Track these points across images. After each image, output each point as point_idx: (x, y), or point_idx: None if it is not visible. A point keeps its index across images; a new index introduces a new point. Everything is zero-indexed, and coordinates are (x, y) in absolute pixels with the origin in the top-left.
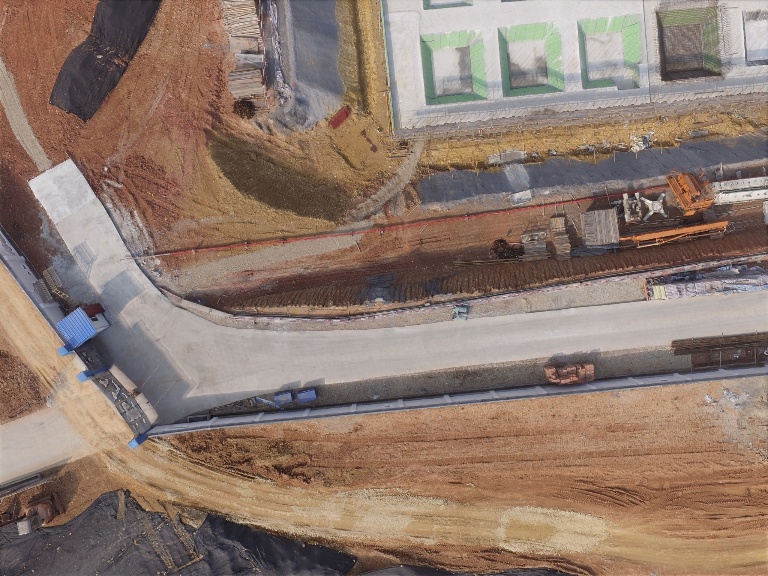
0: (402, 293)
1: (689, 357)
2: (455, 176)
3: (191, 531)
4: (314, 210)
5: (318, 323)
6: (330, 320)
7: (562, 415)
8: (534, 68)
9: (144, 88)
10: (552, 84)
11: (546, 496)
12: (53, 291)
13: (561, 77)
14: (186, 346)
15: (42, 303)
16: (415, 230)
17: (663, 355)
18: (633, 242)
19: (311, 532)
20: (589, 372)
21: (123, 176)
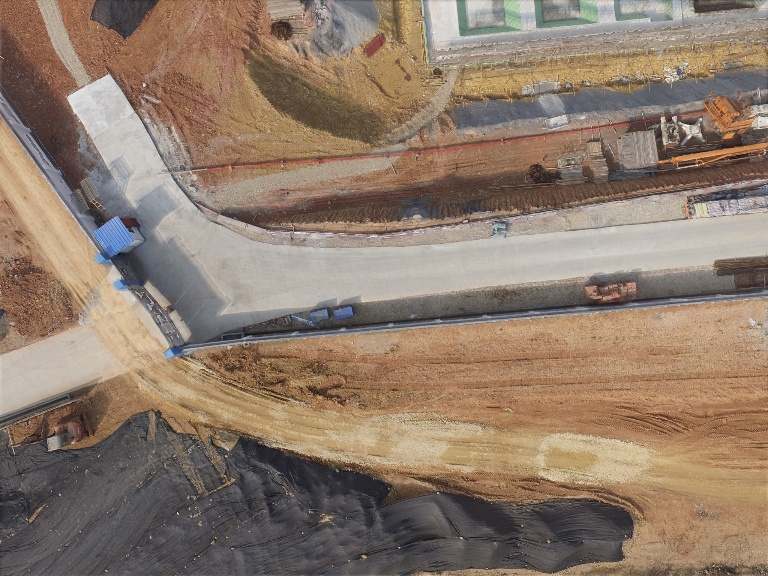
0: (439, 211)
1: (732, 278)
2: (489, 105)
3: (223, 454)
4: (350, 132)
5: (355, 239)
6: (367, 236)
7: (603, 337)
8: (566, 2)
9: (183, 8)
10: (585, 17)
11: (586, 422)
12: (90, 201)
13: (594, 9)
14: (221, 262)
15: (79, 213)
16: (450, 154)
17: (705, 275)
18: (672, 164)
19: (345, 458)
20: (631, 290)
21: (161, 92)
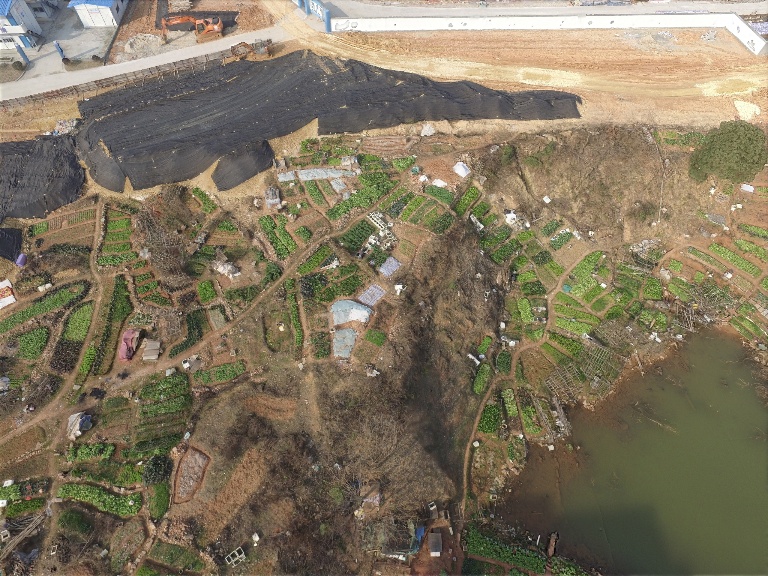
0: None
1: None
2: None
3: None
4: None
5: (414, 5)
6: None
7: None
8: None
9: None
10: None
11: (542, 65)
12: None
13: None
14: None
15: None
16: None
17: None
18: None
19: (409, 71)
20: None
21: None
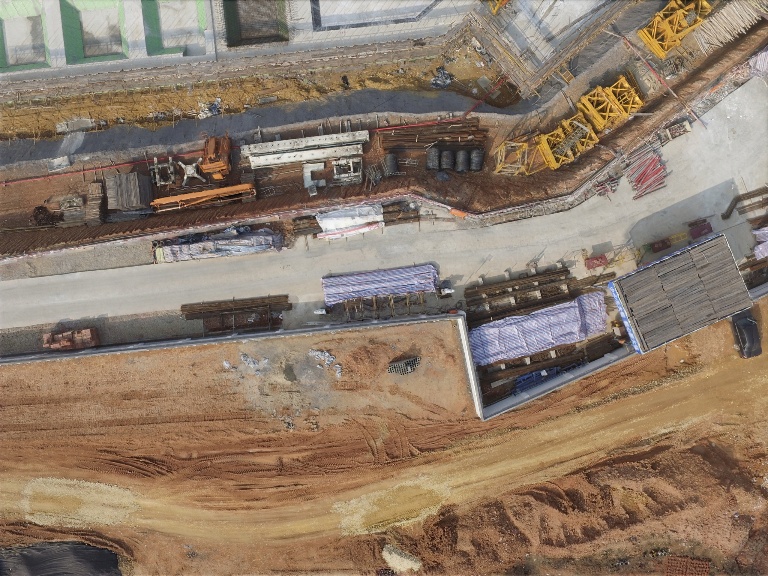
0: None
1: (201, 322)
2: (14, 144)
3: None
4: None
5: None
6: None
7: (76, 382)
8: (108, 36)
9: None
10: (124, 52)
11: (70, 467)
12: None
13: (127, 44)
14: None
15: None
16: None
17: (174, 320)
18: None
19: None
20: (85, 337)
21: None
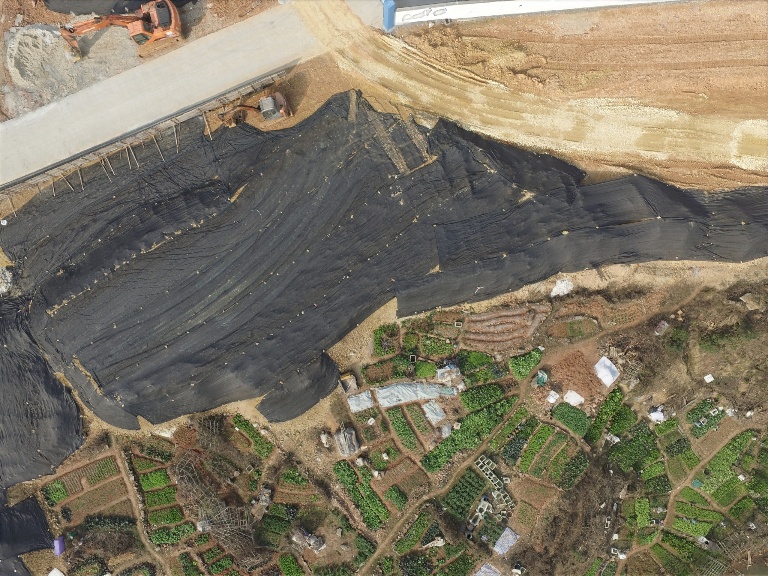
0: None
1: None
2: None
3: (424, 132)
4: None
5: None
6: None
7: None
8: None
9: None
10: None
11: None
12: None
13: None
14: None
15: None
16: None
17: None
18: None
19: (541, 143)
20: None
21: None
